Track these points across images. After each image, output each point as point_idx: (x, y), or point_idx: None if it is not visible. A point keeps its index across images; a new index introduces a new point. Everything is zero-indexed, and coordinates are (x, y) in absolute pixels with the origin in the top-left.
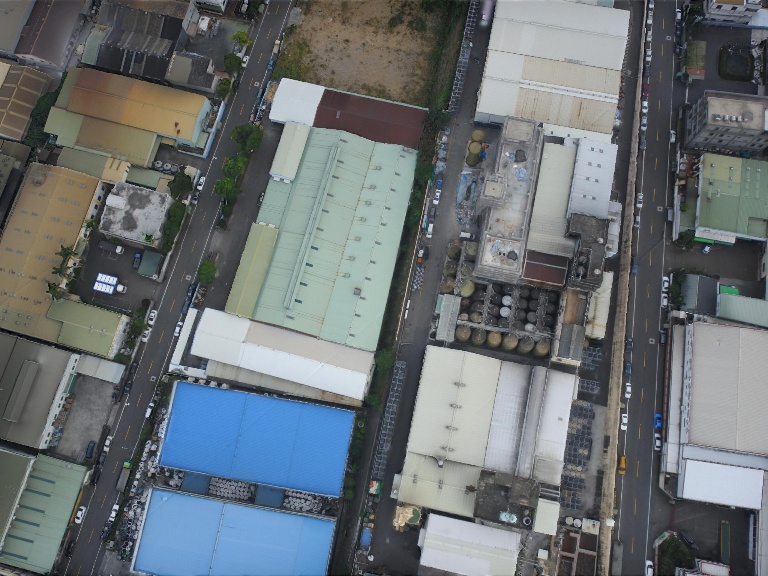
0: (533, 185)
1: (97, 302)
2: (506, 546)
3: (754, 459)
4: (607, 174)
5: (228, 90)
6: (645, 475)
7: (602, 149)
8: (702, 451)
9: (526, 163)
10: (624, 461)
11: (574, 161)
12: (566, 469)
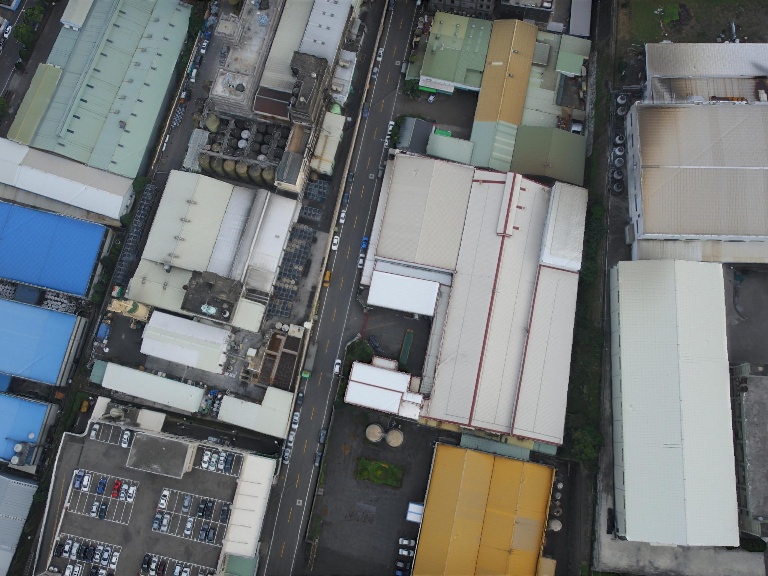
0: (271, 30)
1: None
2: (215, 340)
3: (437, 275)
4: (338, 23)
5: None
6: (347, 289)
7: (337, 1)
8: (392, 266)
9: (268, 11)
10: (328, 275)
11: (311, 10)
12: (280, 281)
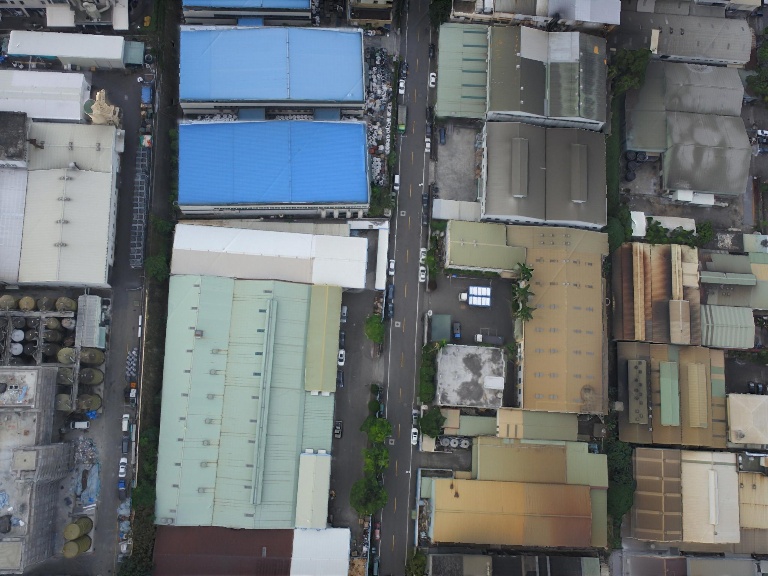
0: None
1: (485, 280)
2: None
3: None
4: None
5: None
6: None
7: None
8: None
9: None
10: None
11: None
12: None
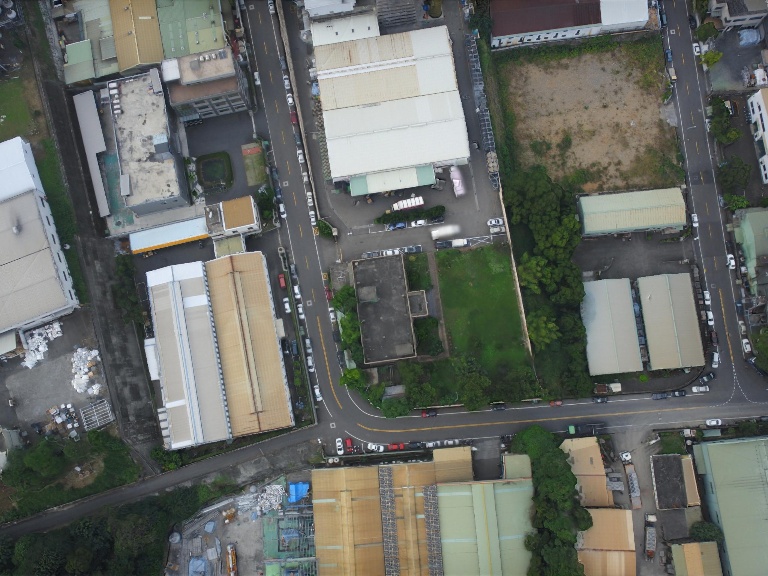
0: None
1: None
2: None
3: None
4: None
5: (697, 8)
6: None
7: None
8: None
9: None
10: None
11: None
12: None
